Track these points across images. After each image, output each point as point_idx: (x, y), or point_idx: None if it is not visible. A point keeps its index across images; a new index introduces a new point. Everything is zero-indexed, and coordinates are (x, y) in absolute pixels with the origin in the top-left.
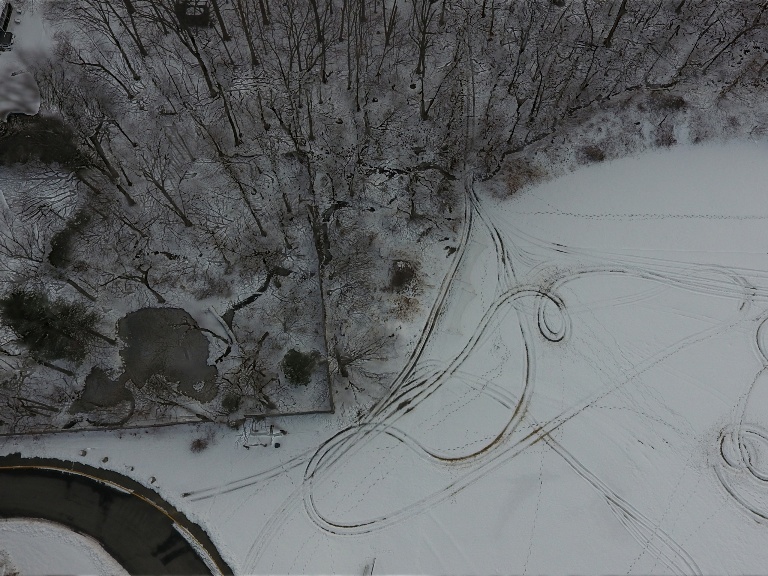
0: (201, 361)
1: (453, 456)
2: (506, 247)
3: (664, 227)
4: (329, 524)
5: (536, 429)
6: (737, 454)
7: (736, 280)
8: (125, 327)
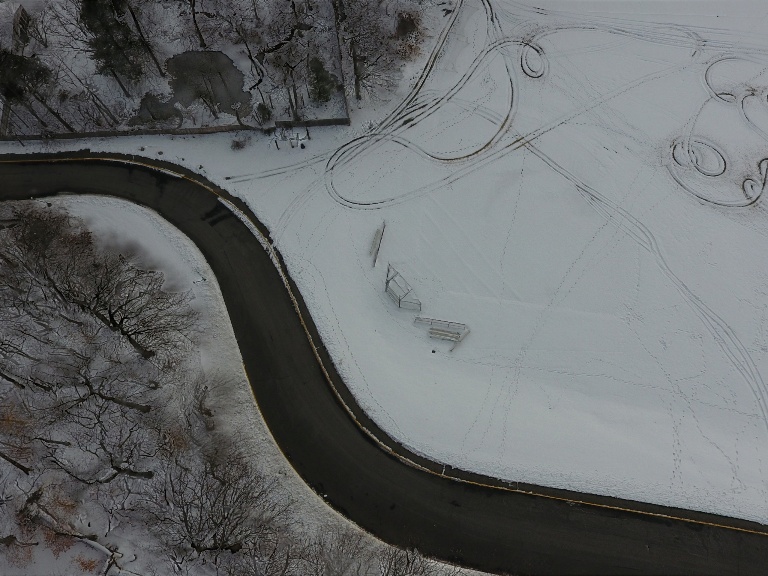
0: (237, 88)
1: (449, 157)
2: (494, 10)
3: None
4: (347, 201)
5: (519, 139)
6: (686, 157)
7: (689, 35)
8: (173, 65)
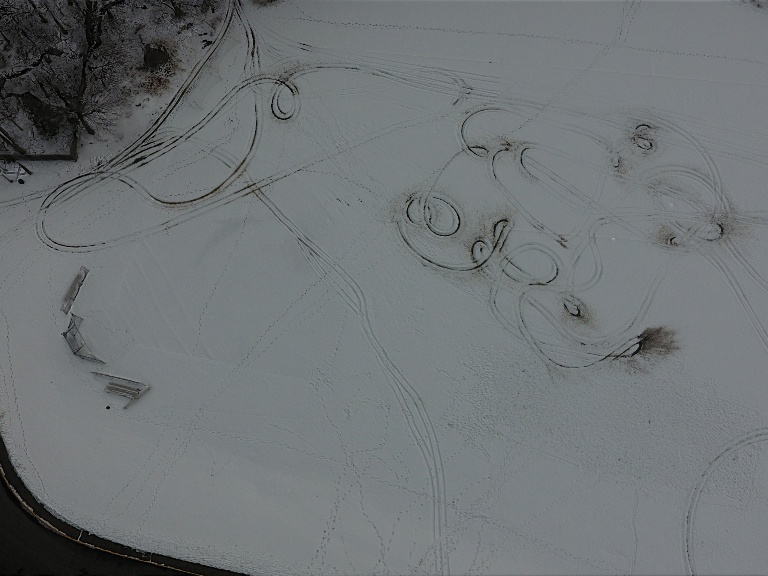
0: None
1: (173, 200)
2: (257, 43)
3: (402, 36)
4: (54, 243)
5: (250, 185)
6: (420, 214)
7: (456, 81)
8: None
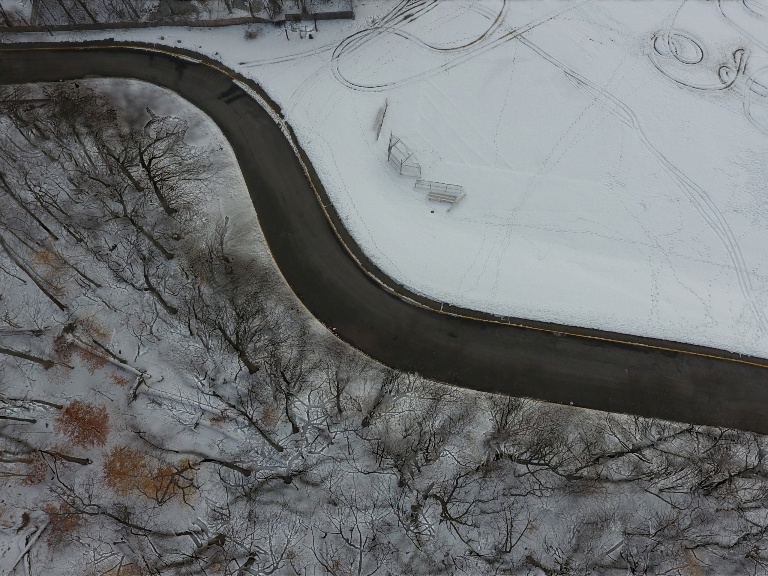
0: None
1: (447, 47)
2: None
3: None
4: (352, 84)
5: (511, 31)
6: (666, 47)
7: None
8: None
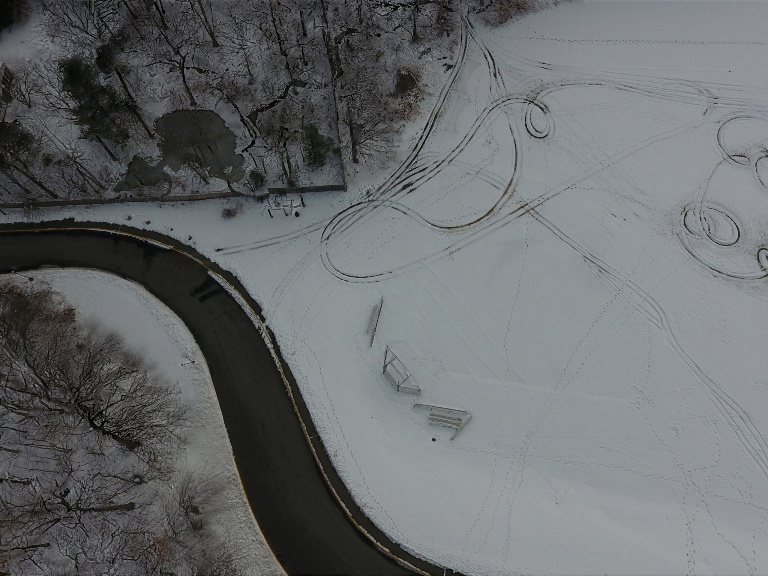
0: (229, 151)
1: (450, 225)
2: (497, 65)
3: (638, 50)
4: (343, 274)
5: (523, 205)
6: (698, 225)
7: (700, 91)
8: (162, 125)
